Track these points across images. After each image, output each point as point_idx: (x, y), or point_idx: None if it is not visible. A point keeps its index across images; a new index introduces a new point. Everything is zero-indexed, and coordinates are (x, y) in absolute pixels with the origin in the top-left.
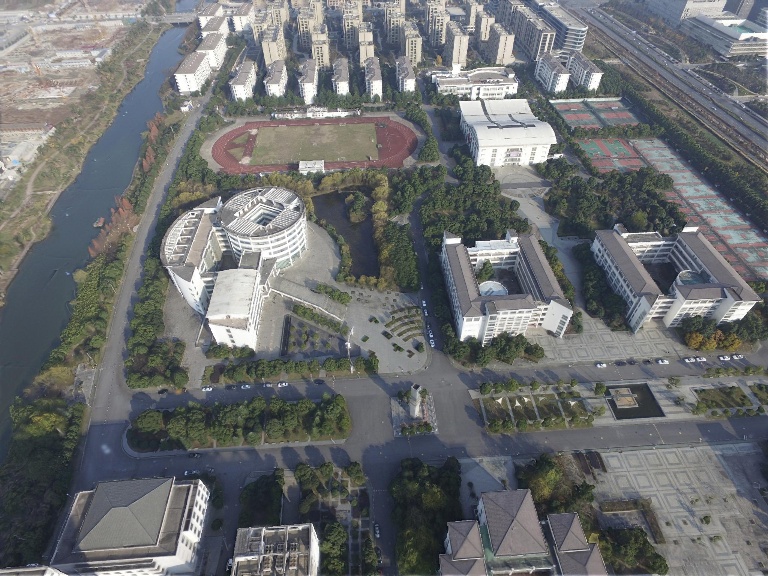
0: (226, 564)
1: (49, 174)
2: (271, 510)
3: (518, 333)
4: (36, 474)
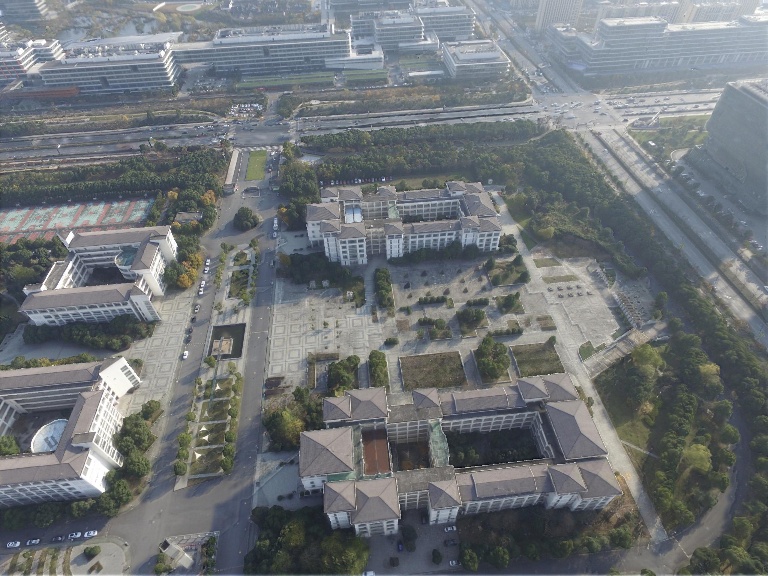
0: None
1: None
2: None
3: (119, 423)
4: None
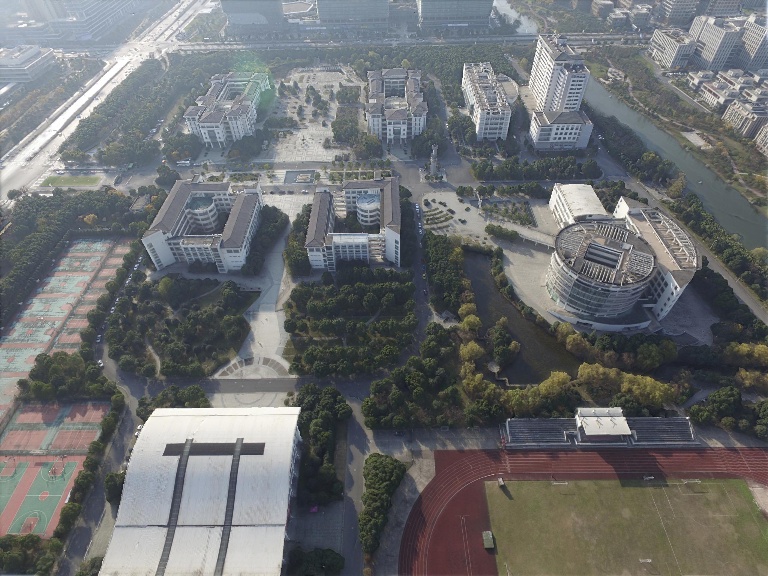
0: (516, 137)
1: None
2: None
3: None
4: None
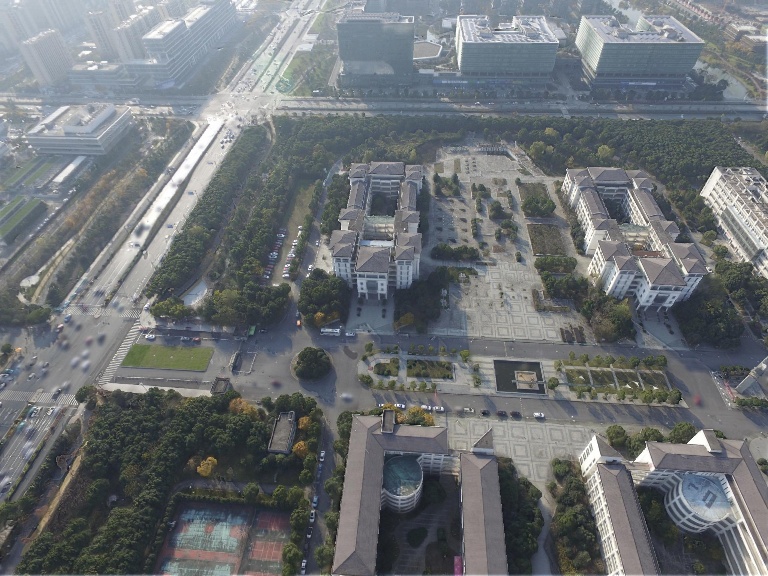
0: None
1: None
2: None
3: None
4: None
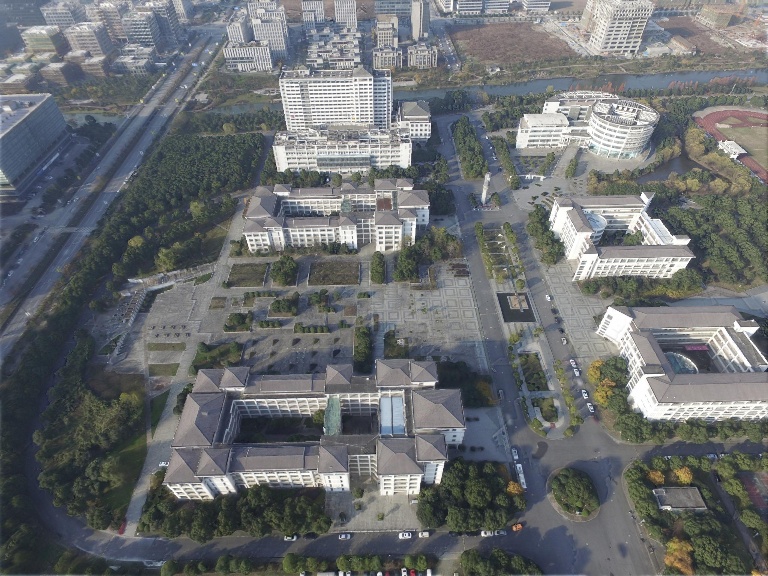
0: None
1: (638, 62)
2: (424, 156)
3: (567, 253)
4: (436, 102)
